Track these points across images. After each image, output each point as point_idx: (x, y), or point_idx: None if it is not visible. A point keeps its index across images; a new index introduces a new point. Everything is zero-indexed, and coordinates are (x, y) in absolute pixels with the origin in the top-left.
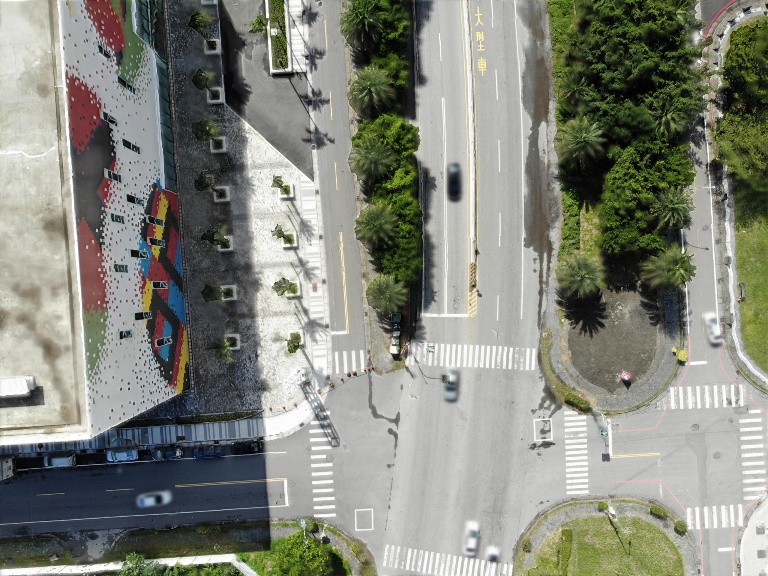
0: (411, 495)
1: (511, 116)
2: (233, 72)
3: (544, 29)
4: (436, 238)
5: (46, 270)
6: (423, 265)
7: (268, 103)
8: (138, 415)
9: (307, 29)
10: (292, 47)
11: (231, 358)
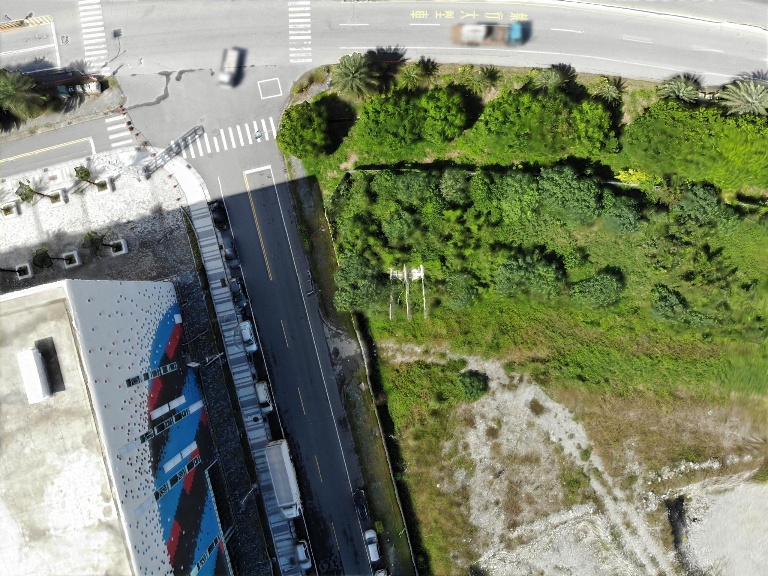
0: (237, 47)
1: None
2: None
3: None
4: None
5: None
6: None
7: None
8: (208, 328)
9: None
10: None
11: (107, 232)
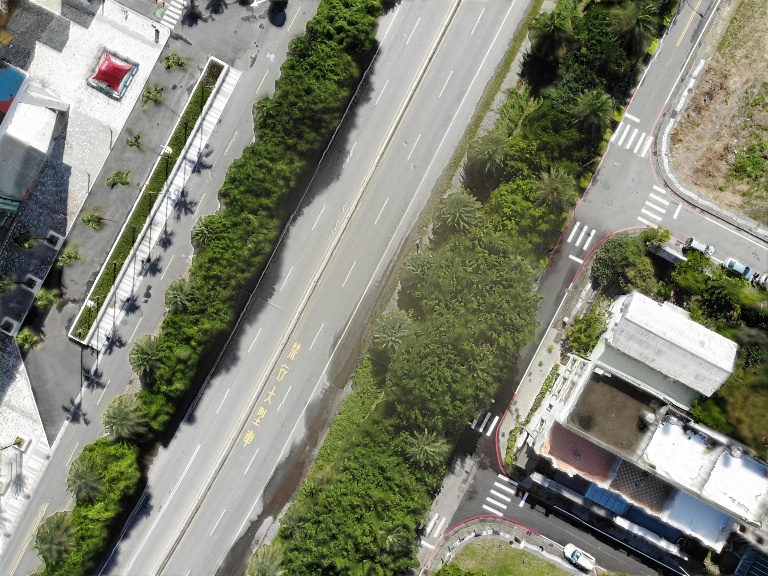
0: None
1: (248, 495)
2: (38, 314)
3: (320, 439)
4: (124, 558)
5: None
6: (99, 574)
7: (52, 358)
8: None
9: (123, 315)
10: (100, 323)
11: None
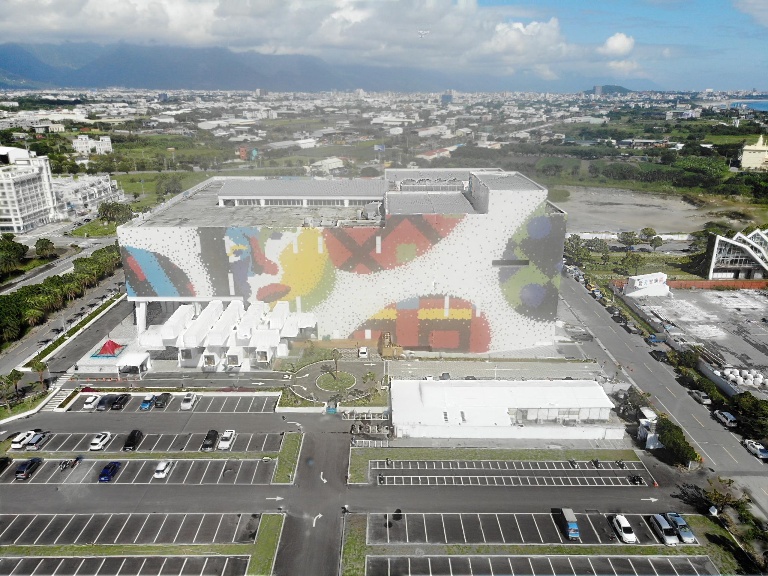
0: None
1: (26, 284)
2: None
3: None
4: None
5: (212, 188)
6: None
7: None
8: None
9: None
10: None
11: None
